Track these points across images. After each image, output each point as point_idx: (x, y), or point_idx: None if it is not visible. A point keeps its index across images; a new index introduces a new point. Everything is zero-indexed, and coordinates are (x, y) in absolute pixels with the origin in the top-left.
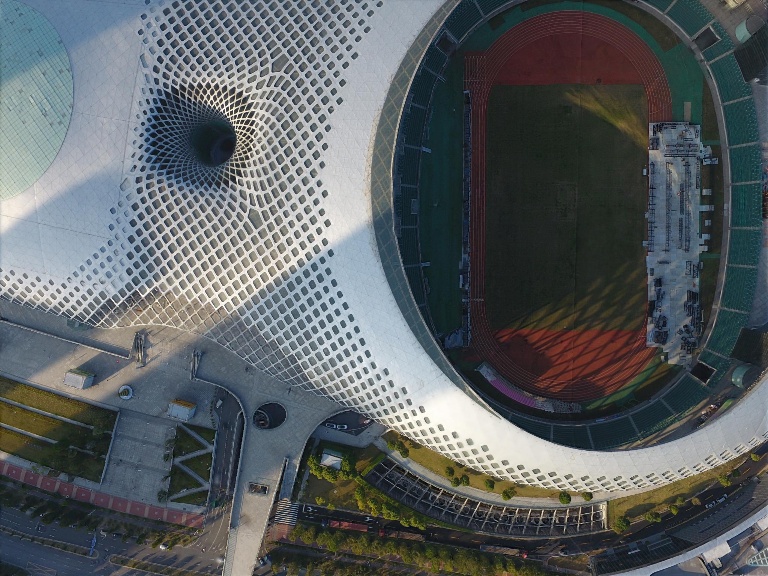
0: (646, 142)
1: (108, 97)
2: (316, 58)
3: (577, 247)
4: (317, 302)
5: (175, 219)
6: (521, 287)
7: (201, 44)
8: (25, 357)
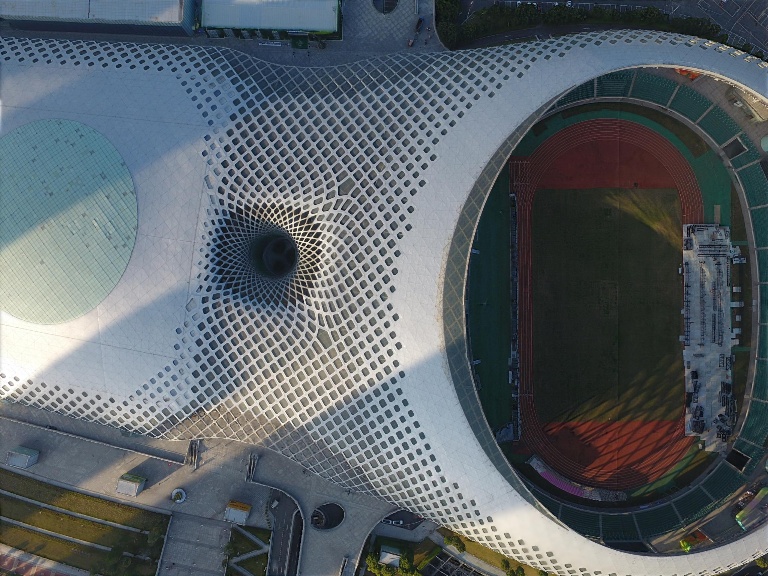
0: (680, 243)
1: (173, 218)
2: (383, 183)
3: (619, 342)
4: (387, 420)
5: (242, 338)
6: (567, 381)
7: (266, 165)
8: (72, 463)
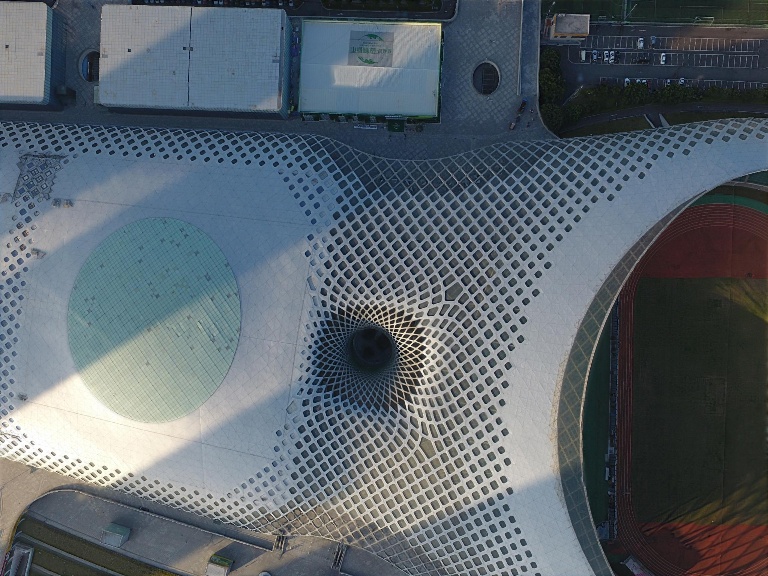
0: None
1: (275, 320)
2: (493, 290)
3: (726, 442)
4: (491, 534)
5: (342, 442)
6: (668, 481)
7: (369, 266)
8: (162, 541)
